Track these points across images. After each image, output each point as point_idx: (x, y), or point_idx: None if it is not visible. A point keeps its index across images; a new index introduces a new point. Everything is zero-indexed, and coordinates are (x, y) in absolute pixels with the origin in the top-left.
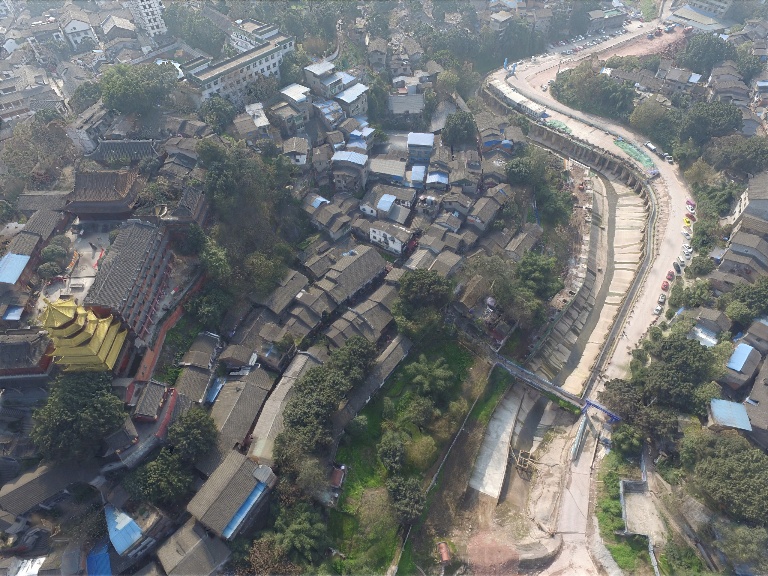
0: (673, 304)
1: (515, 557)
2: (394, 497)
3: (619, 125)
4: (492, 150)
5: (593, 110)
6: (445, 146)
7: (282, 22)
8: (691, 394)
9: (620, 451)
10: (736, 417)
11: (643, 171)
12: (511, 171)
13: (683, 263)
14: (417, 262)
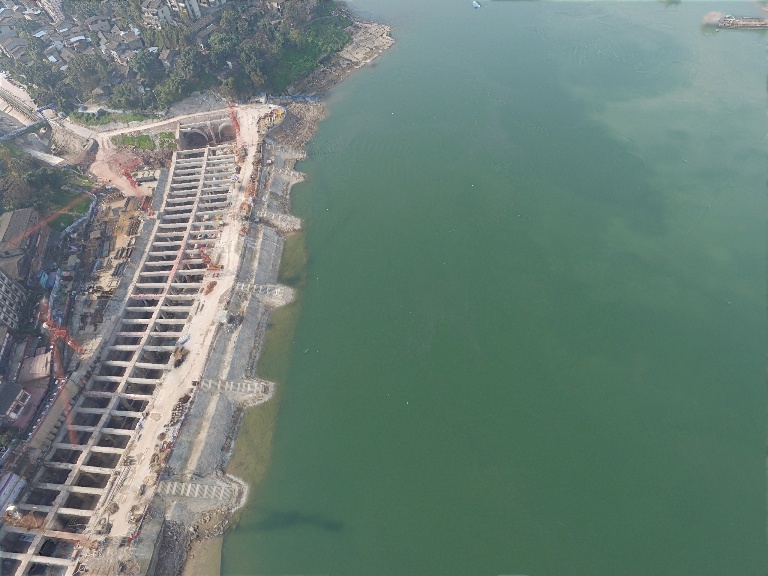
0: (22, 80)
1: (86, 151)
2: (18, 165)
3: None
4: None
5: None
6: None
7: None
8: (53, 73)
9: (68, 109)
10: None
11: None
12: None
13: (8, 76)
14: None
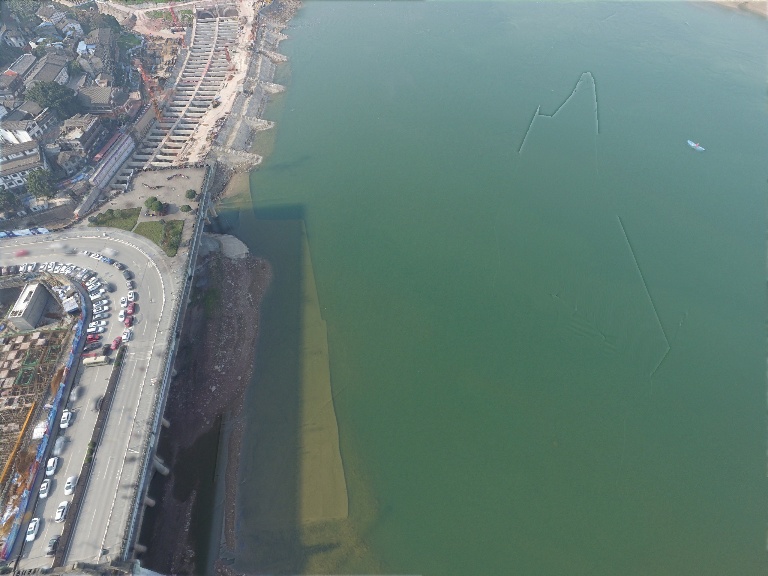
0: None
1: (129, 19)
2: None
3: None
4: None
5: None
6: None
7: None
8: None
9: None
10: None
11: None
12: None
13: None
14: None
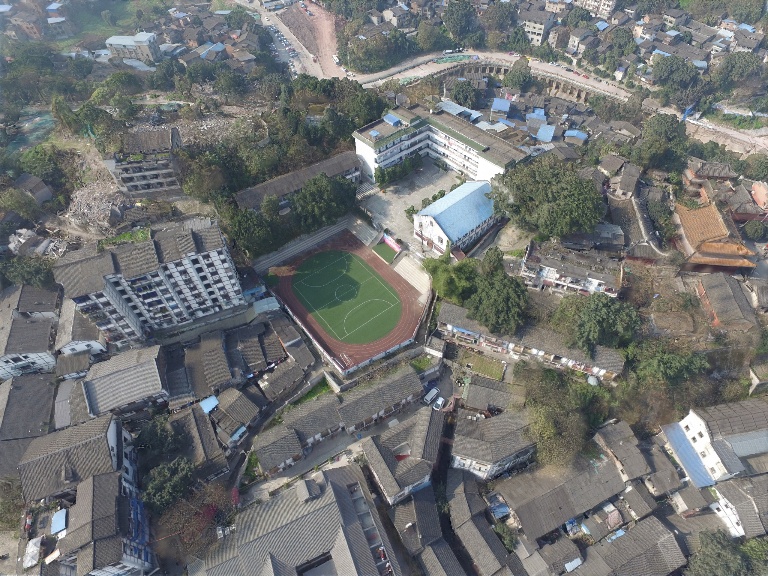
0: None
1: None
2: None
3: (416, 57)
4: (486, 92)
5: (395, 61)
6: (480, 110)
7: (368, 112)
8: None
9: None
10: (701, 62)
11: (473, 61)
12: (525, 83)
13: None
14: (624, 137)
